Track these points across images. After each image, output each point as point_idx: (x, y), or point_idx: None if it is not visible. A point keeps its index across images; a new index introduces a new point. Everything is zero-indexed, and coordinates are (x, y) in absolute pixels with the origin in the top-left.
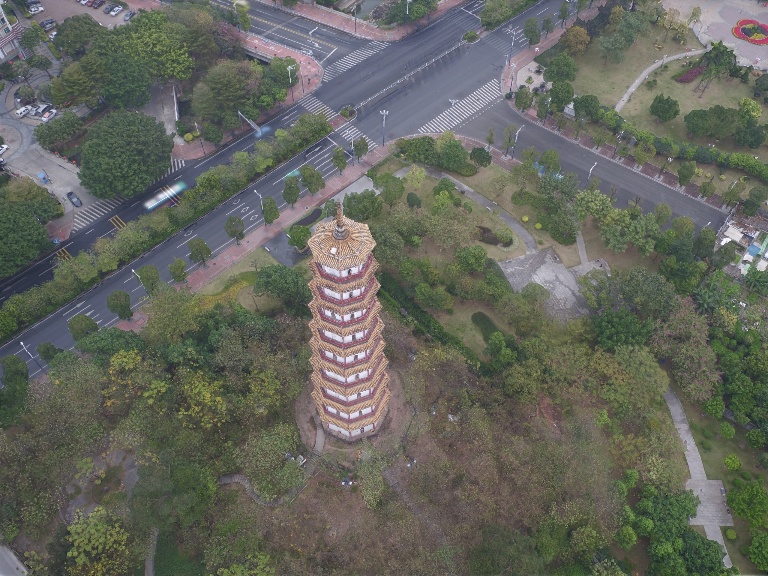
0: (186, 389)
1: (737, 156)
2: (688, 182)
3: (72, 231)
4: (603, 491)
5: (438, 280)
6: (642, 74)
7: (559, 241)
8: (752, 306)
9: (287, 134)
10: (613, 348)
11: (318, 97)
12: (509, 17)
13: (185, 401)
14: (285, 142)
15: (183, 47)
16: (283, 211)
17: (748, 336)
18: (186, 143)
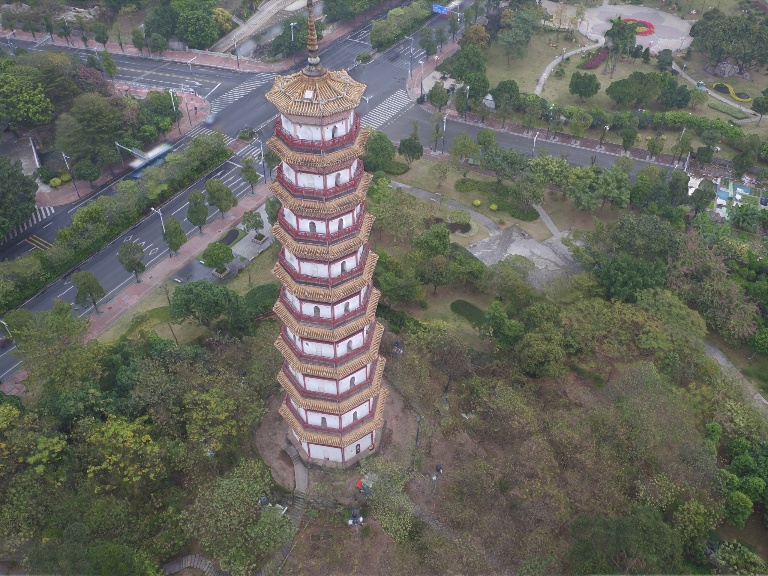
0: (94, 438)
1: (671, 114)
2: (633, 144)
3: None
4: (697, 446)
5: (401, 271)
6: (547, 69)
7: (521, 218)
8: (747, 243)
9: (180, 156)
10: (632, 296)
11: (209, 127)
12: (398, 39)
13: None
14: (179, 166)
15: (37, 88)
16: (190, 239)
17: (766, 261)
18: (53, 189)
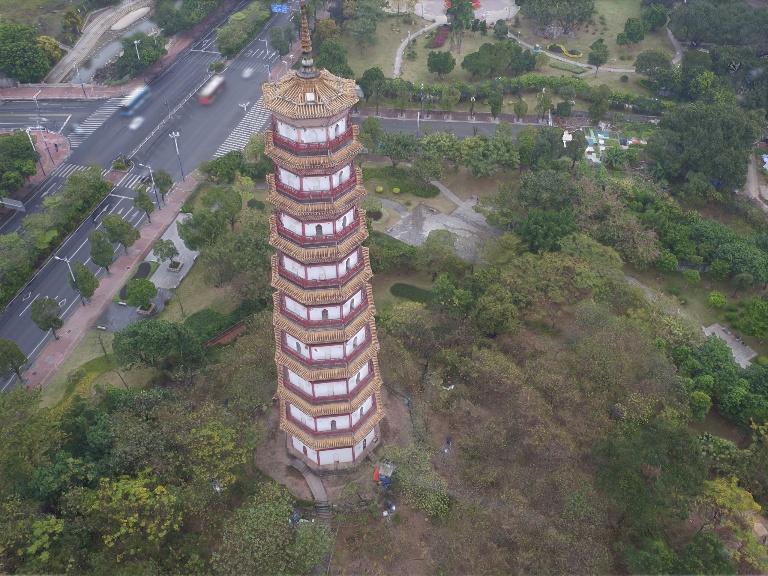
0: (97, 507)
1: (525, 78)
2: (500, 110)
3: None
4: (660, 360)
5: None
6: (397, 53)
7: (425, 196)
8: None
9: (61, 198)
10: (555, 245)
11: (75, 163)
12: (245, 43)
13: (96, 537)
14: (62, 209)
15: None
16: None
17: (649, 192)
18: None
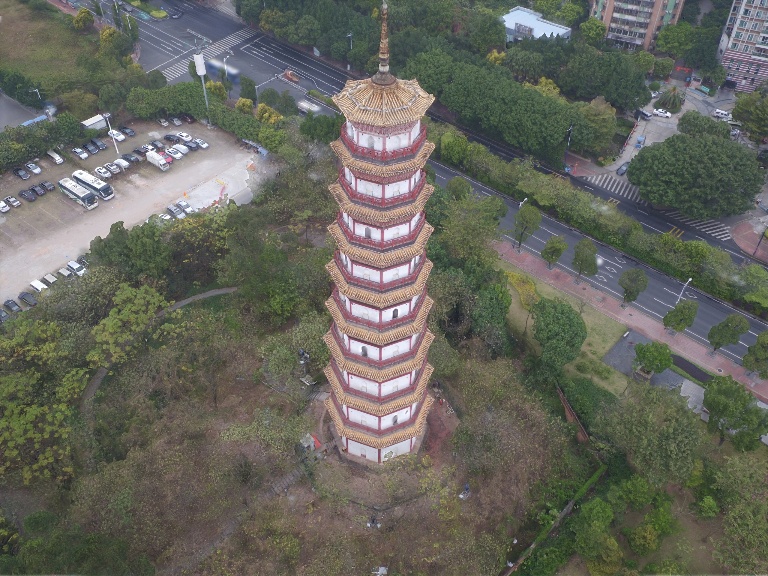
0: None
1: None
2: None
3: (585, 177)
4: None
5: (640, 549)
6: None
7: None
8: None
9: None
10: None
11: None
12: None
13: None
14: None
15: None
16: (700, 344)
17: None
18: (760, 235)
